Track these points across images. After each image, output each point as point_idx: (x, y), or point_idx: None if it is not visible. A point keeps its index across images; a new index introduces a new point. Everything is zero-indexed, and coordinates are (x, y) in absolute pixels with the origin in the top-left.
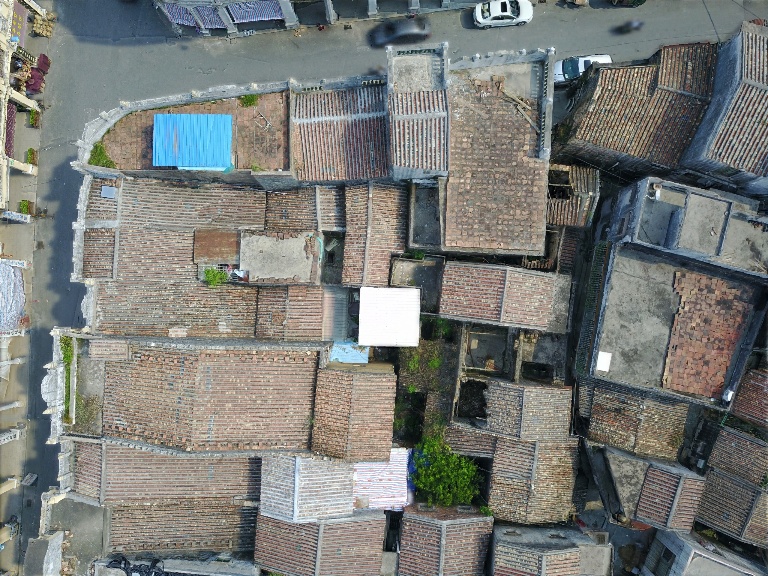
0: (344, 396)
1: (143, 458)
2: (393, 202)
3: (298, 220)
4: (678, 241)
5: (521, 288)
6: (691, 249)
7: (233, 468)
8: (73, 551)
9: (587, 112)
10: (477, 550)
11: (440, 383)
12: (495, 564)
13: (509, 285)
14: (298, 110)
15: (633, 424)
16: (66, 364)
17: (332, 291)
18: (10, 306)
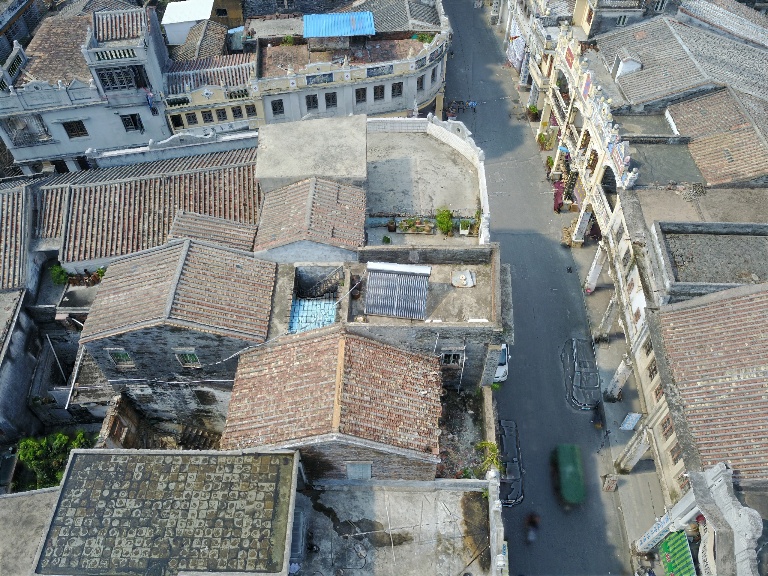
0: None
1: None
2: None
3: None
4: None
5: None
6: None
7: None
8: None
9: None
10: None
11: None
12: None
13: None
14: None
15: None
16: None
17: None
18: None
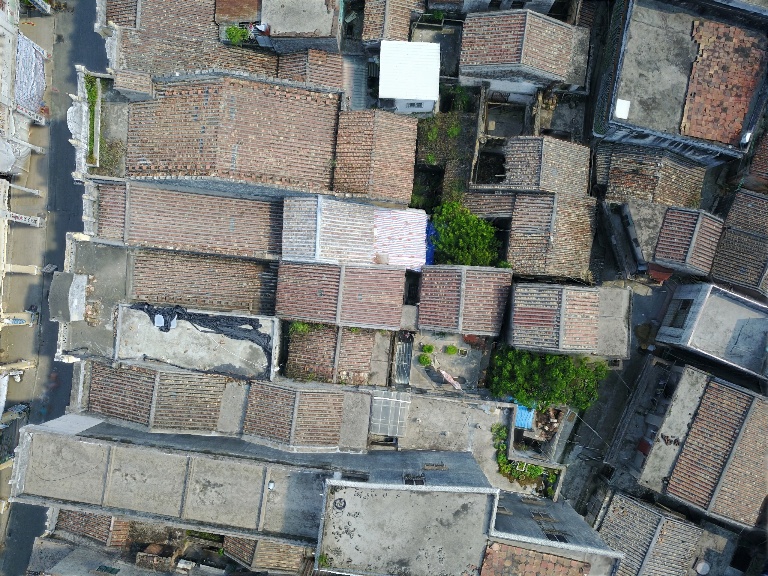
0: (366, 133)
1: (166, 202)
2: None
3: None
4: None
5: (541, 34)
6: None
7: (254, 223)
8: (97, 296)
9: None
10: (496, 301)
11: (458, 153)
12: (515, 306)
13: (529, 29)
14: None
15: (651, 183)
16: (90, 105)
17: (351, 61)
18: (31, 86)
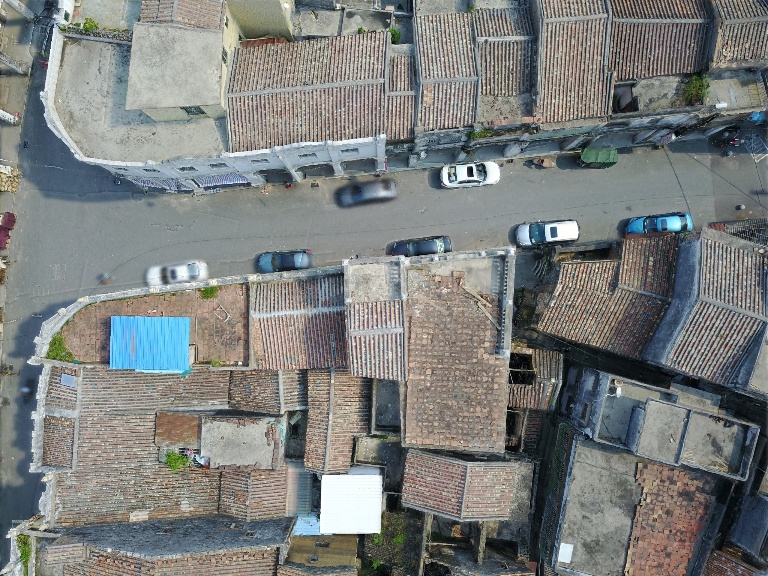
0: None
1: None
2: (356, 385)
3: (261, 398)
4: (637, 449)
5: (482, 481)
6: (650, 456)
7: None
8: None
9: (548, 306)
10: None
11: (404, 558)
12: None
13: (470, 480)
14: (258, 302)
15: None
16: (24, 561)
17: (296, 466)
18: None
